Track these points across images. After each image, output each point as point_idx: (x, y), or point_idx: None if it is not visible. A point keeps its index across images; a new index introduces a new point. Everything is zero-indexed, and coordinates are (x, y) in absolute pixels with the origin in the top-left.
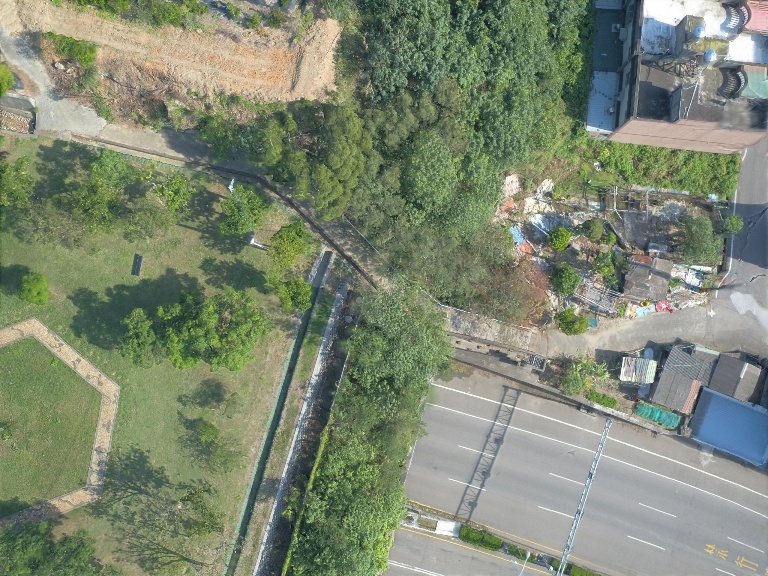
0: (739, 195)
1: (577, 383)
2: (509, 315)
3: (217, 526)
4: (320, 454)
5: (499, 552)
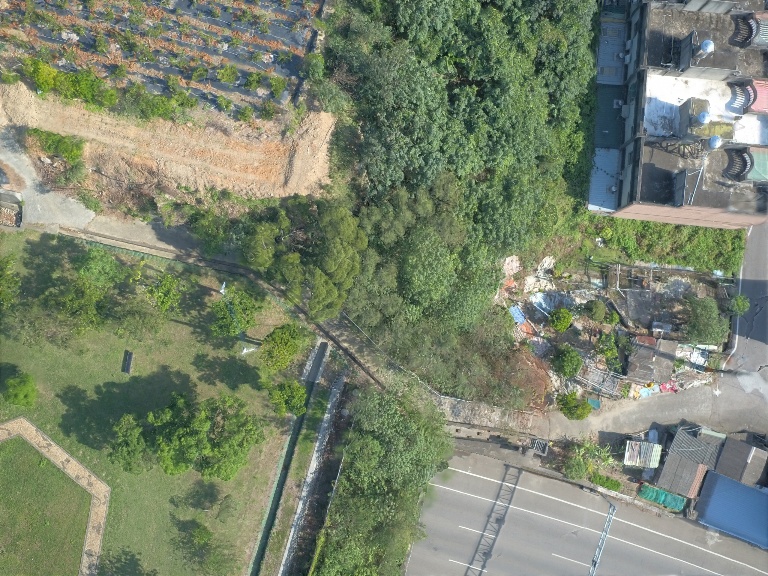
0: (745, 270)
1: (580, 468)
2: (510, 404)
3: None
4: (316, 557)
5: None
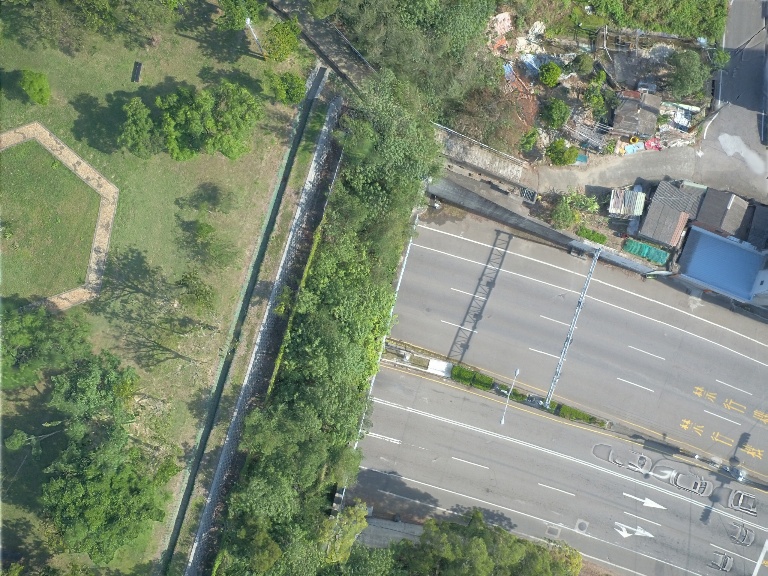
0: (727, 39)
1: (567, 213)
2: (500, 137)
3: (212, 325)
4: (313, 253)
5: (490, 393)
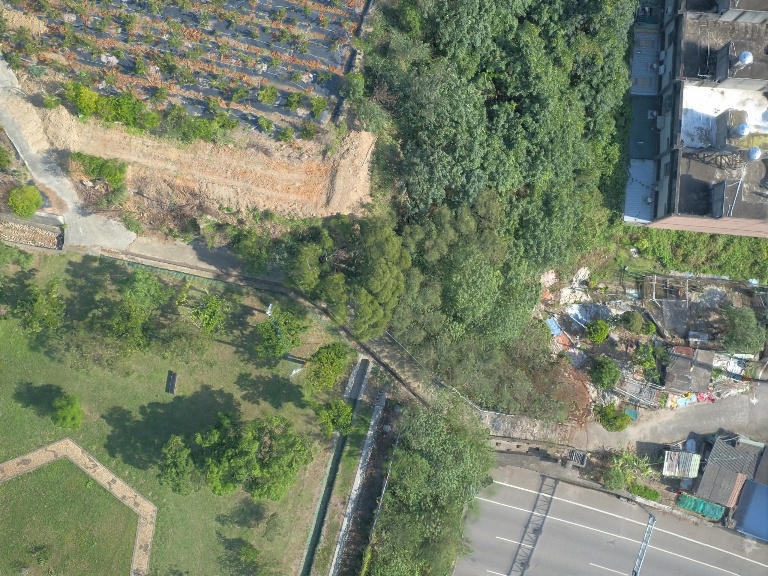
0: None
1: (619, 480)
2: (550, 417)
3: None
4: (363, 574)
5: None
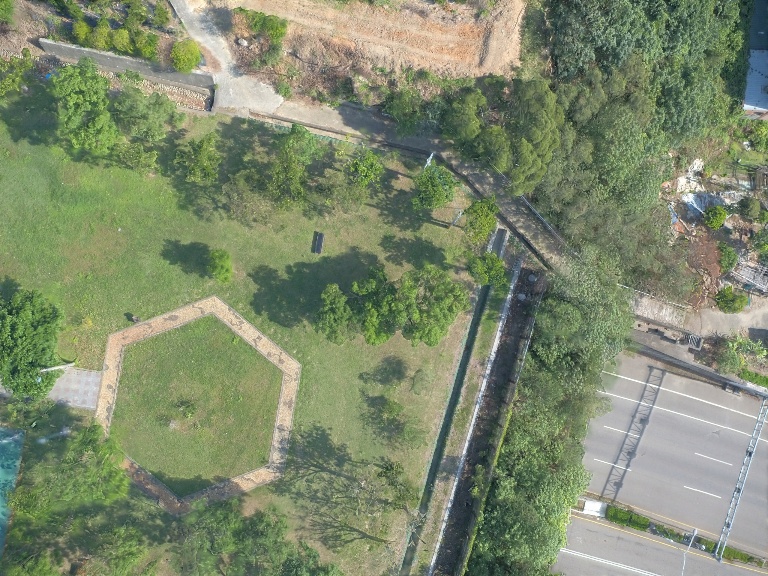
0: None
1: (735, 361)
2: (676, 293)
3: (400, 503)
4: (505, 431)
5: (645, 532)
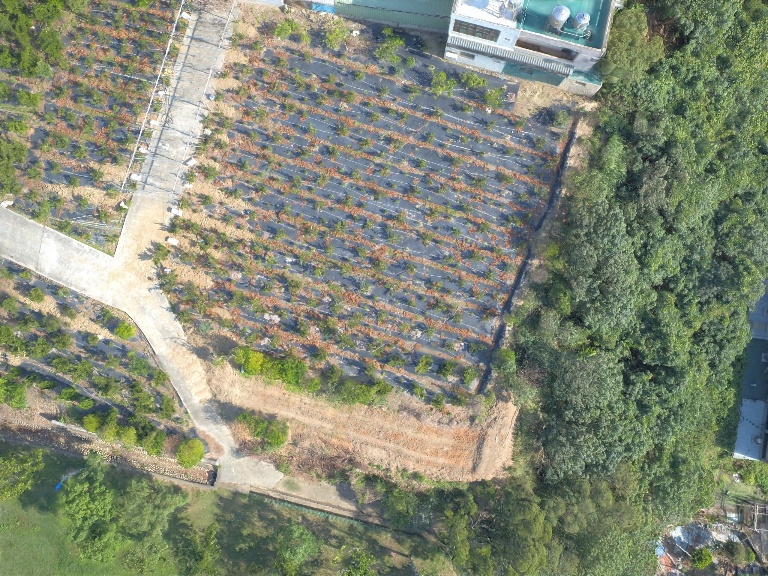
0: None
1: None
2: None
3: None
4: None
5: None
